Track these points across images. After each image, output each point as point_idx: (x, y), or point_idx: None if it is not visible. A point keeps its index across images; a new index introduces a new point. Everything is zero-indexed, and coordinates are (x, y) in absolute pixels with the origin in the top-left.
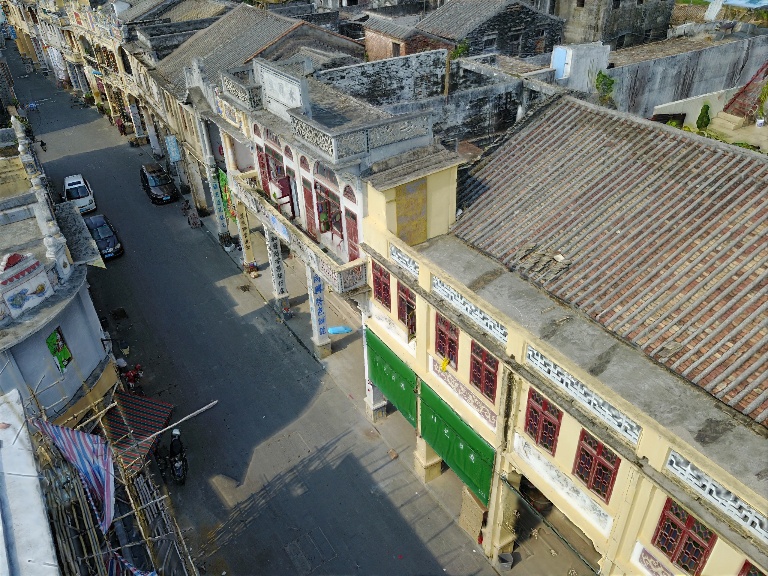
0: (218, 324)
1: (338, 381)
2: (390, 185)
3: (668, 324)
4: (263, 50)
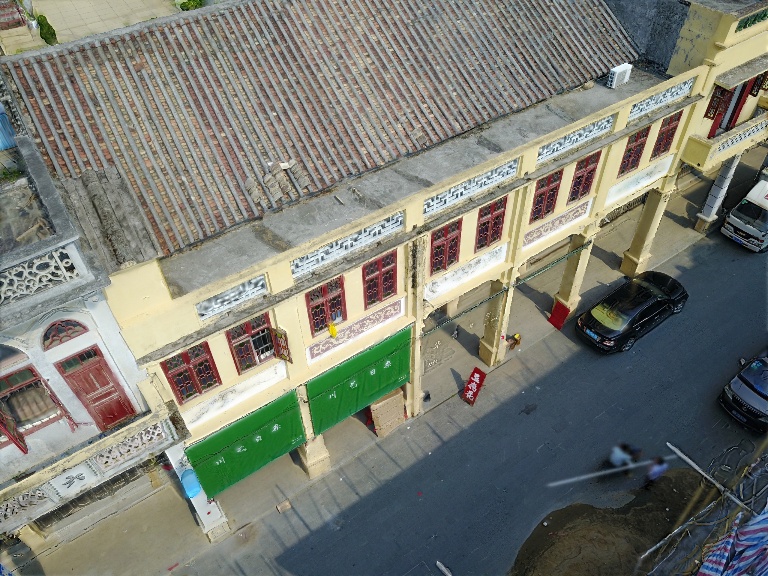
0: None
1: None
2: (147, 242)
3: (395, 127)
4: None
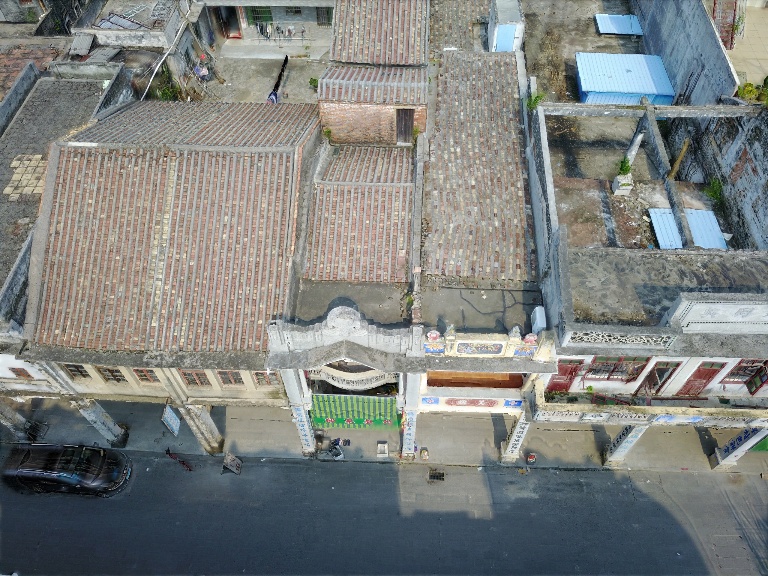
0: (496, 533)
1: (658, 468)
2: None
3: None
4: (295, 220)
